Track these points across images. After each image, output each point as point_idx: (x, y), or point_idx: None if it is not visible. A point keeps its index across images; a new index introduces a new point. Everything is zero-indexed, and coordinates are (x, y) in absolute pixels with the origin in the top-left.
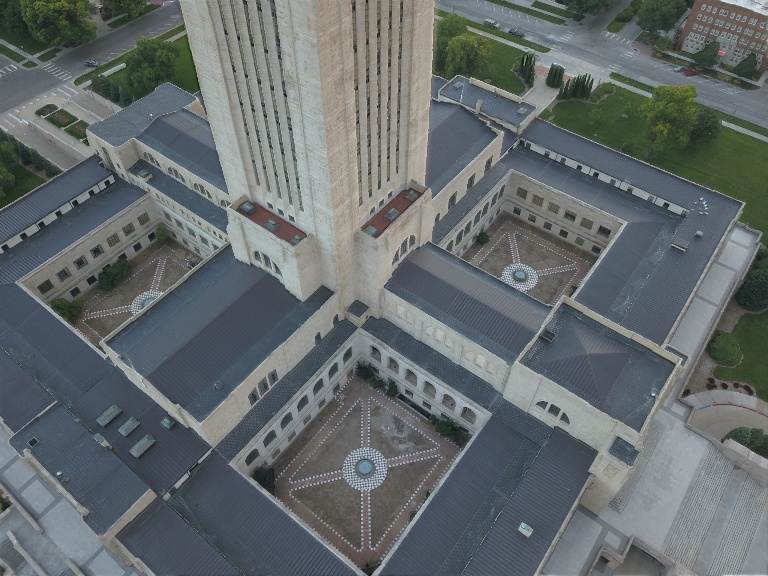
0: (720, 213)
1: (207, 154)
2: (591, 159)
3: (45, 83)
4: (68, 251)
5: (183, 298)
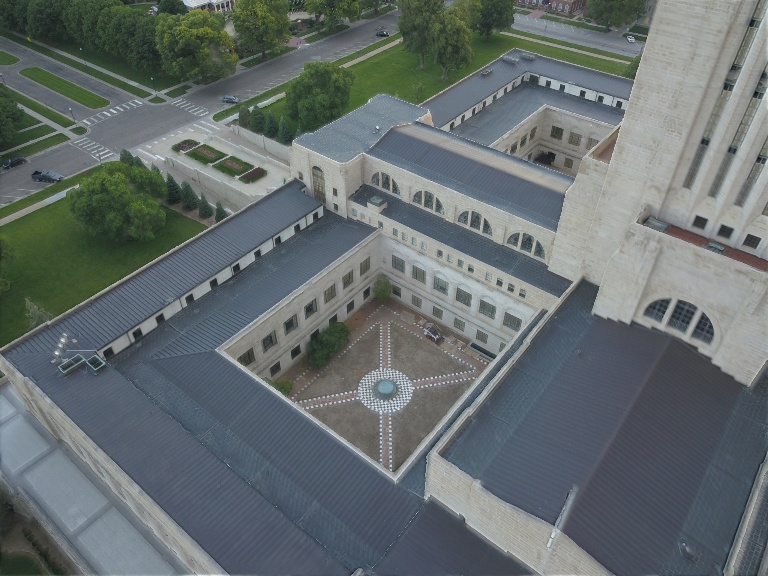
0: None
1: (480, 172)
2: None
3: (178, 118)
4: (284, 305)
5: (537, 377)
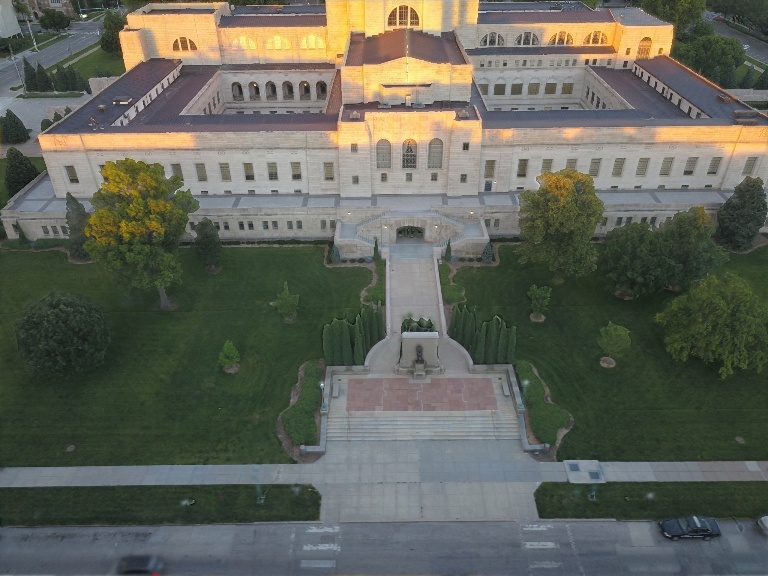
0: (74, 127)
1: None
2: (241, 127)
3: None
4: None
5: None
